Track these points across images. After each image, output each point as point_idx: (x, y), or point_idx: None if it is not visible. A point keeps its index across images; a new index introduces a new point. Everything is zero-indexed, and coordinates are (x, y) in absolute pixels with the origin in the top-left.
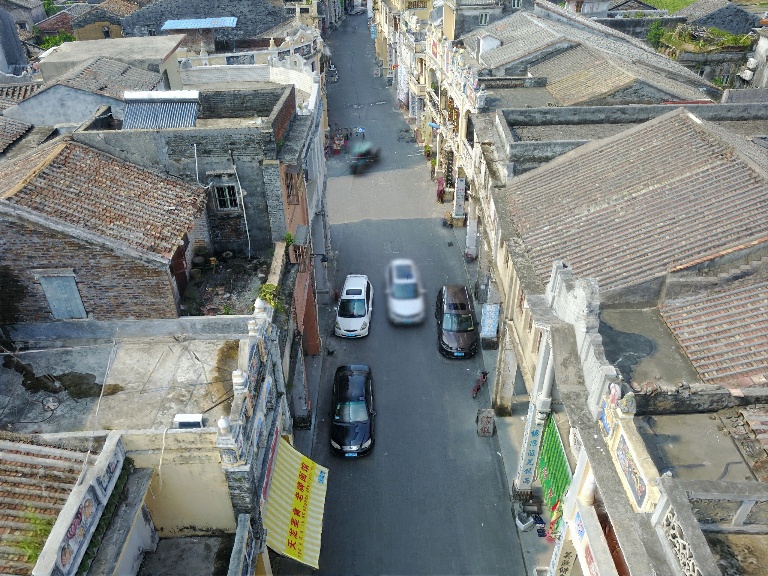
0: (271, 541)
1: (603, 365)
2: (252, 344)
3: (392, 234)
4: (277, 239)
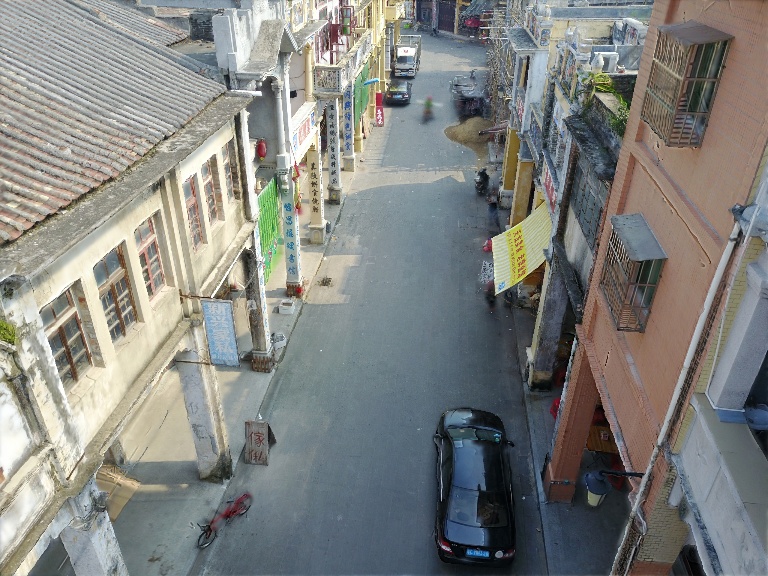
0: (534, 214)
1: (274, 2)
2: None
3: None
4: None
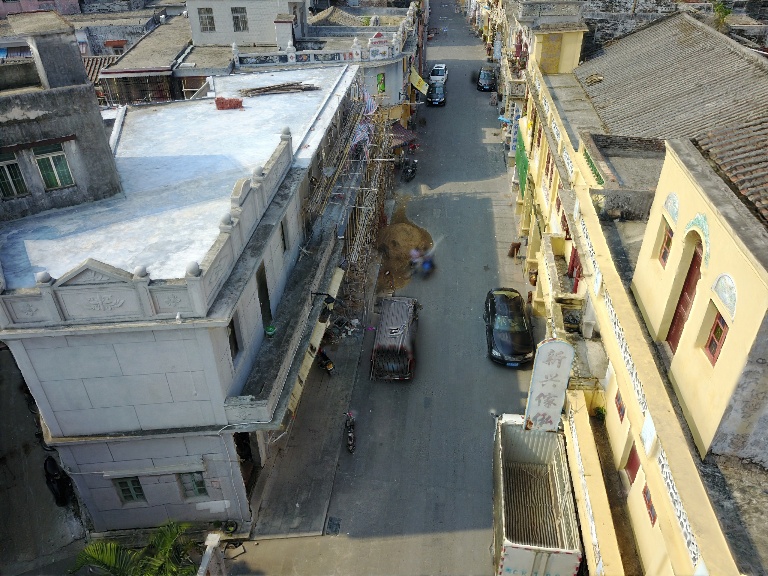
0: None
1: None
2: (413, 7)
3: (459, 63)
4: (416, 0)
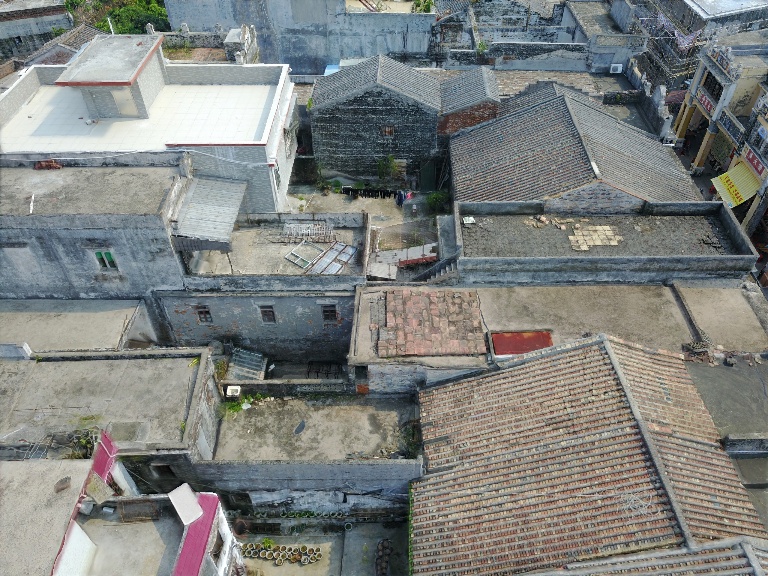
0: None
1: None
2: None
3: None
4: None
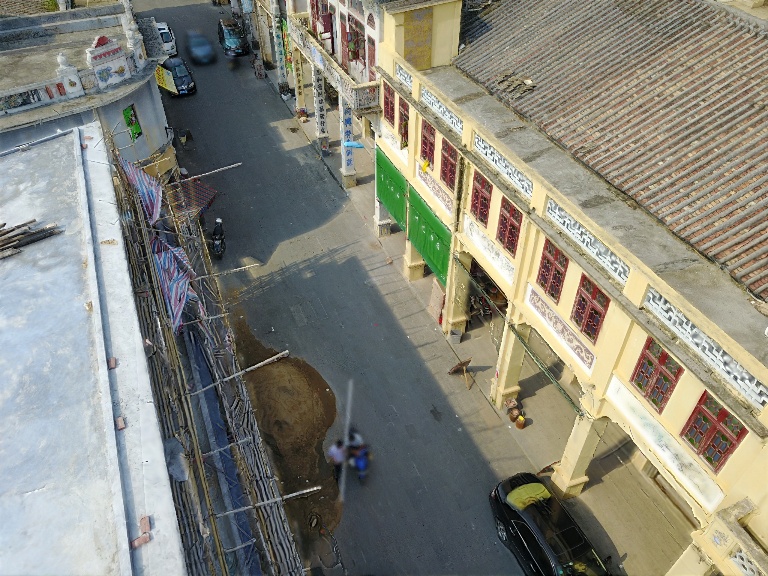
0: None
1: None
2: None
3: (177, 13)
4: None
